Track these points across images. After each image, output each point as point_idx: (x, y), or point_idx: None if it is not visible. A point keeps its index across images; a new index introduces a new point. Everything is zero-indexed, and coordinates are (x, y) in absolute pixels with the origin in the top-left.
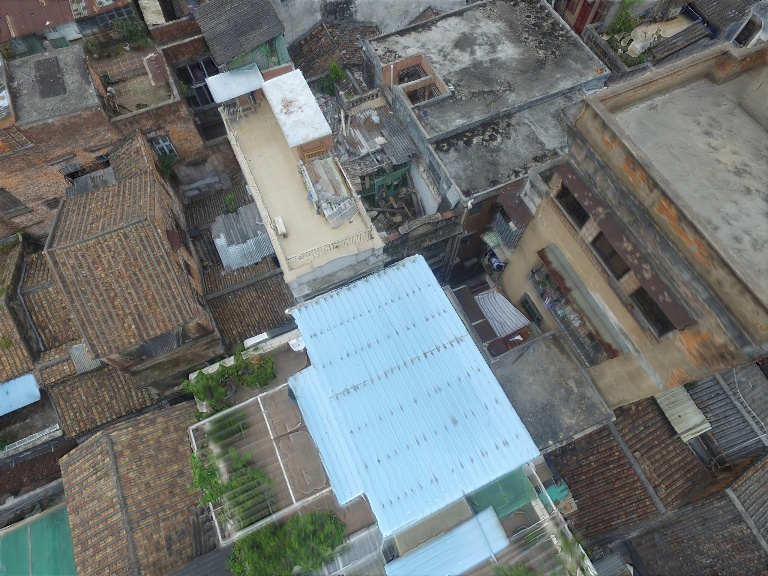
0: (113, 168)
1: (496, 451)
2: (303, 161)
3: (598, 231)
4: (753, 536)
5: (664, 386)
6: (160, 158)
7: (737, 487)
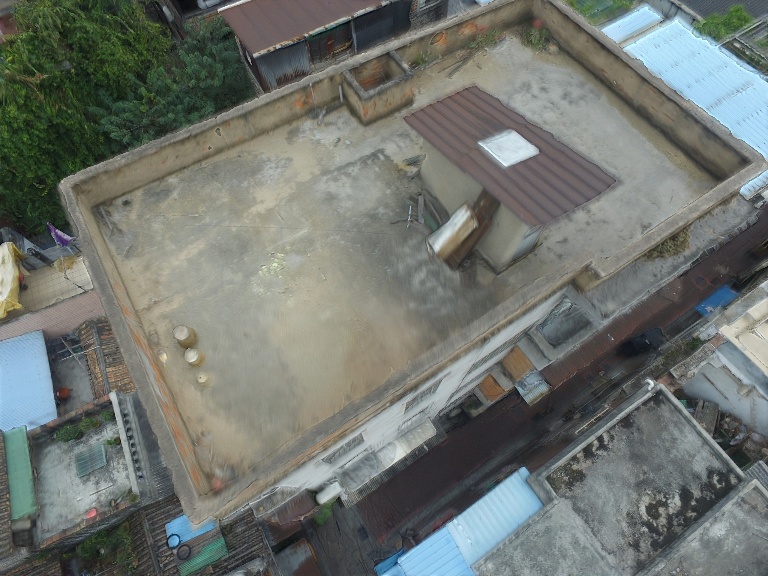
0: None
1: None
2: None
3: None
4: None
5: None
6: None
7: None
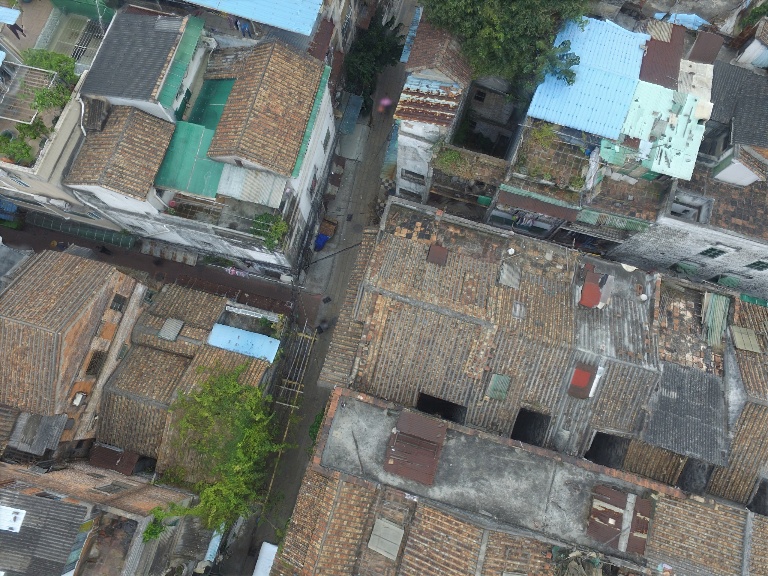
0: (7, 440)
1: None
2: None
3: None
4: None
5: None
6: None
7: None
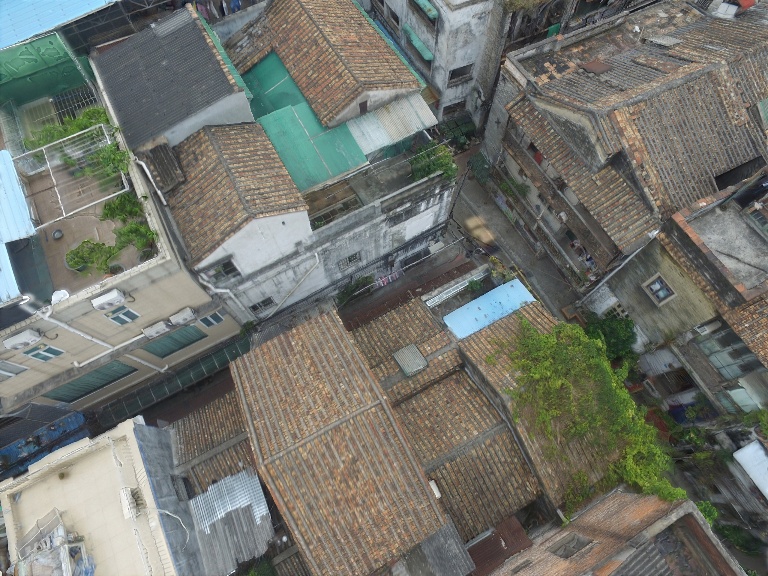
0: None
1: None
2: None
3: None
4: None
5: None
6: None
7: None
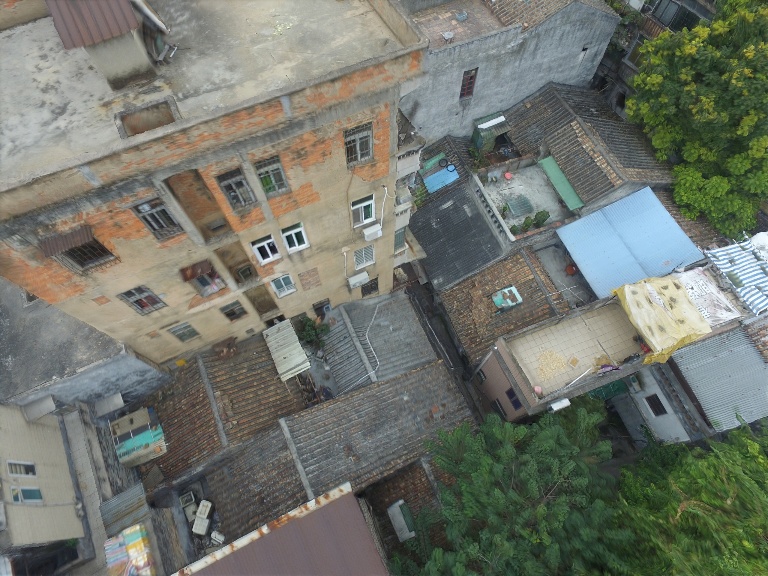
0: None
1: None
2: None
3: None
4: (293, 461)
5: None
6: None
7: (296, 418)
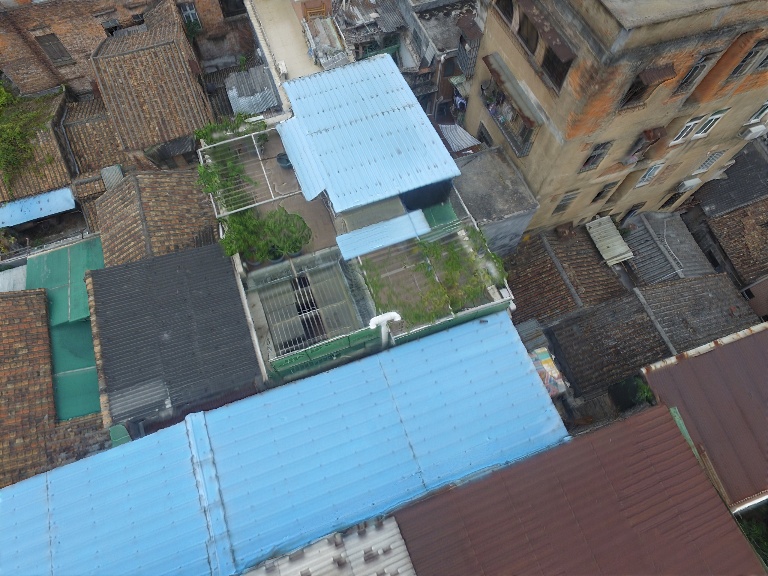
0: (147, 24)
1: (428, 170)
2: (306, 19)
3: (518, 8)
4: (651, 322)
5: (564, 140)
6: (186, 23)
7: (644, 290)
